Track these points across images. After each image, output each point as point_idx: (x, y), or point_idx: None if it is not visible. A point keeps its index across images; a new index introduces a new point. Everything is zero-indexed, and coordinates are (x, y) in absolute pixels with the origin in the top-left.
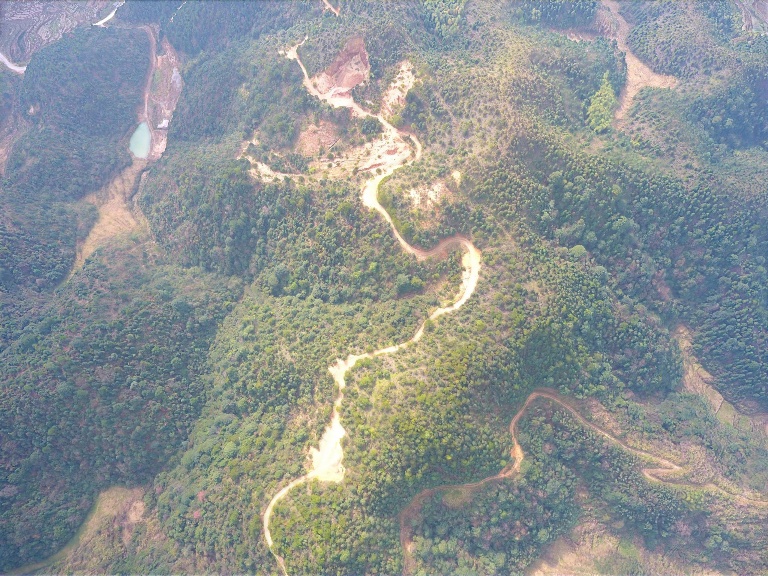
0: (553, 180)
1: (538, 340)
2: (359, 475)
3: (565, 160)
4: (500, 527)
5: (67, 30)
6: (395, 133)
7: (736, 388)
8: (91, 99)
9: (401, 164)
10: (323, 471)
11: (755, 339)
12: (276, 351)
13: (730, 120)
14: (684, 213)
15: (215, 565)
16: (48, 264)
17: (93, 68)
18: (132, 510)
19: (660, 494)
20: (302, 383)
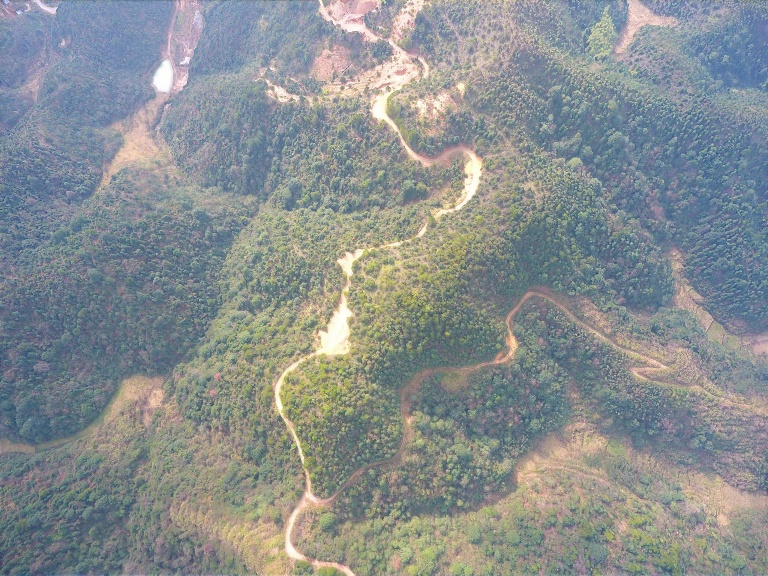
0: (552, 94)
1: (534, 235)
2: (364, 346)
3: (564, 75)
4: (494, 412)
5: None
6: (404, 55)
7: (725, 307)
8: (119, 33)
9: (409, 83)
10: (331, 348)
11: (744, 258)
12: (289, 250)
13: (726, 57)
14: (678, 135)
15: (229, 438)
16: (77, 179)
17: (121, 5)
18: (152, 396)
19: (647, 390)
20: (312, 277)
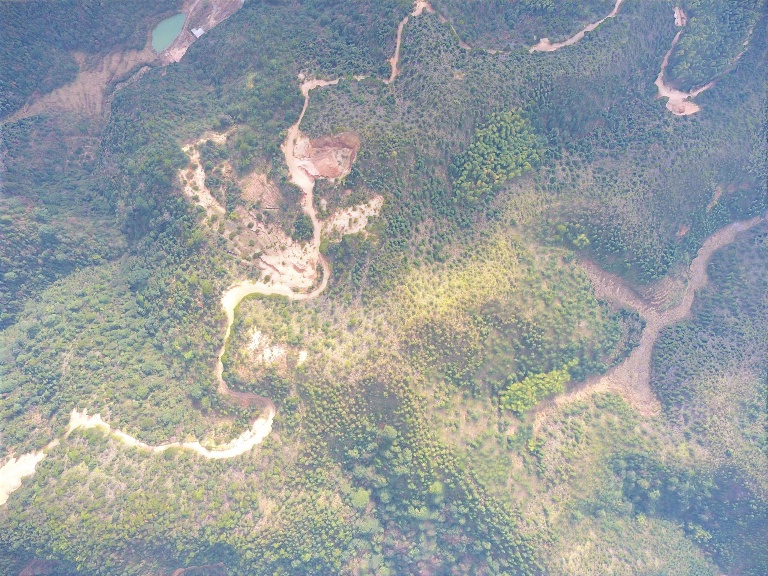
0: (385, 433)
1: (233, 547)
2: (4, 519)
3: (410, 428)
4: None
5: None
6: (316, 254)
7: None
8: None
9: (292, 289)
10: (1, 482)
11: None
12: (64, 350)
13: (657, 494)
14: None
15: None
16: None
17: None
18: None
19: None
20: None
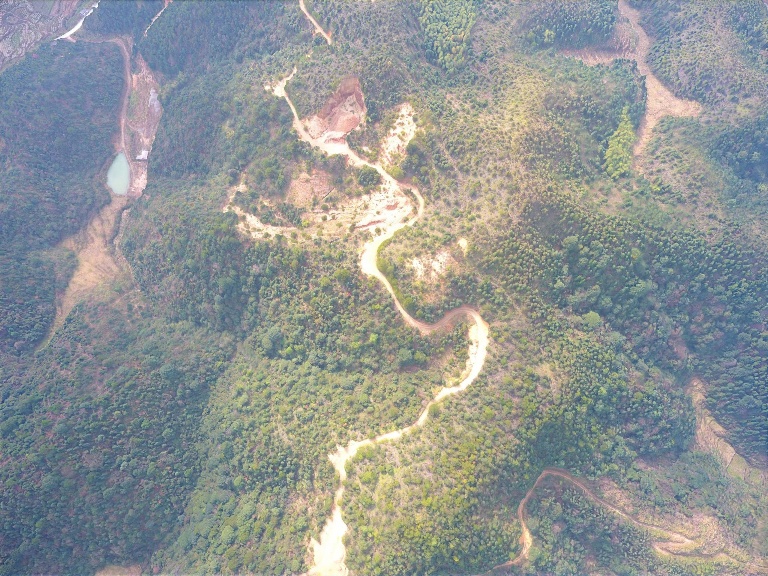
0: (568, 246)
1: (550, 428)
2: None
3: (581, 224)
4: None
5: (31, 44)
6: (395, 185)
7: (749, 443)
8: (61, 132)
9: (402, 222)
10: (325, 568)
11: None
12: (272, 430)
13: (757, 154)
14: (705, 269)
15: None
16: (26, 324)
17: (61, 96)
18: None
19: (670, 569)
20: (301, 467)
